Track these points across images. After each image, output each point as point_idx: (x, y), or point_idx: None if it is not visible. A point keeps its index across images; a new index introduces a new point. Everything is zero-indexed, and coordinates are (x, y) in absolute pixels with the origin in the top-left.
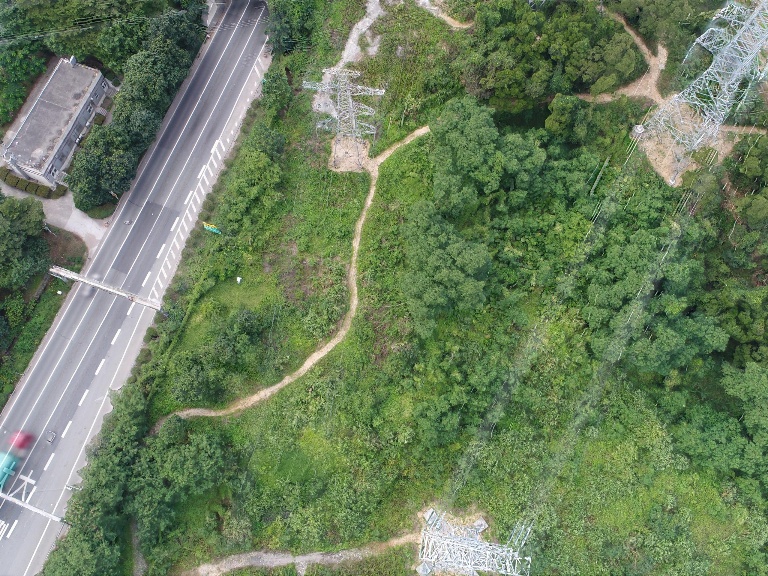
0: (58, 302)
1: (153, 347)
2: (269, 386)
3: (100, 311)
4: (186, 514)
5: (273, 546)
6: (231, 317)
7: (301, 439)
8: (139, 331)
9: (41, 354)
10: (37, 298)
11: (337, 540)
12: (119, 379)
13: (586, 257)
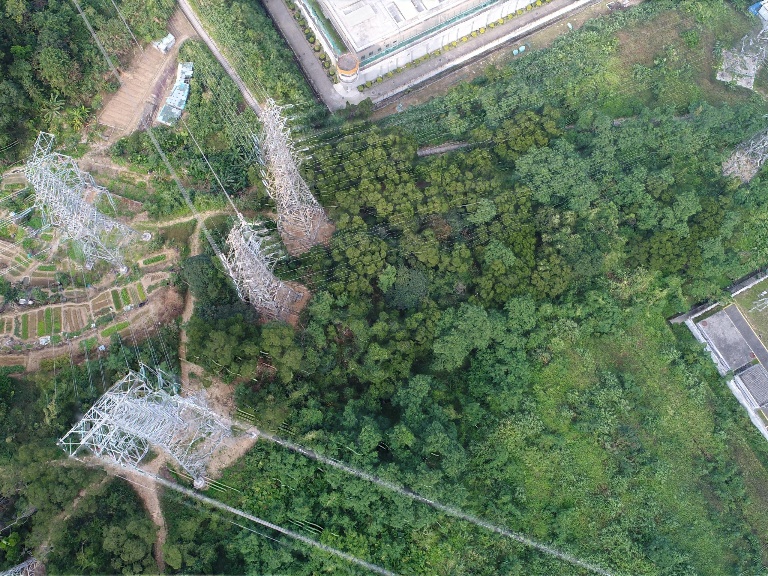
0: None
1: None
2: None
3: None
4: None
5: None
6: None
7: None
8: None
9: None
10: None
11: None
12: None
13: (356, 529)
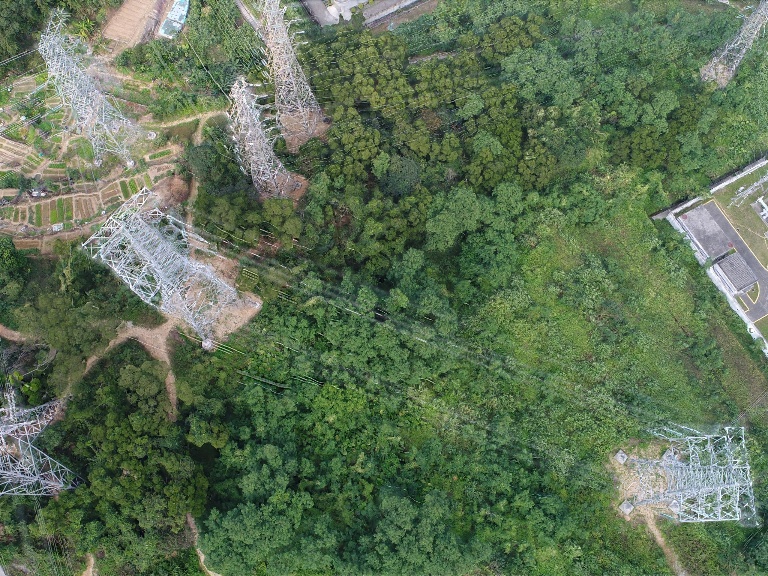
0: None
1: None
2: None
3: None
4: None
5: None
6: None
7: None
8: None
9: None
10: None
11: None
12: None
13: None
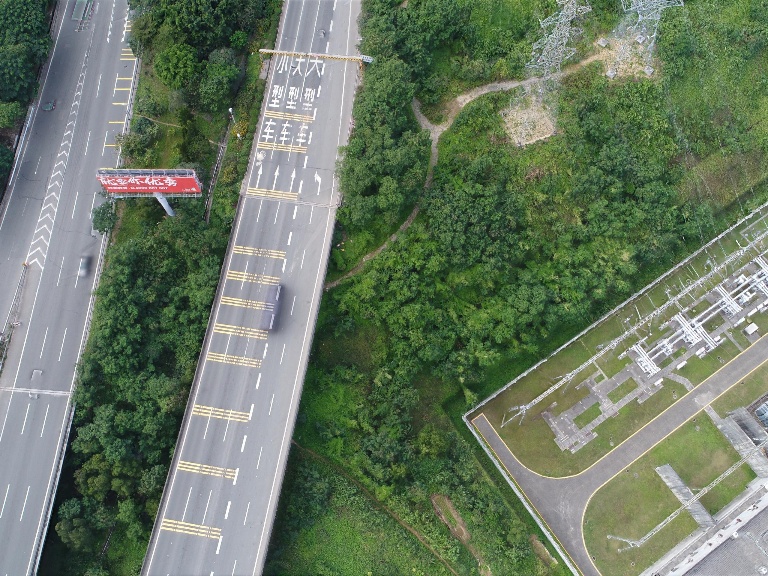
0: None
1: None
2: None
3: None
4: (435, 67)
5: (504, 73)
6: None
7: None
8: None
9: None
10: None
11: None
12: None
13: None
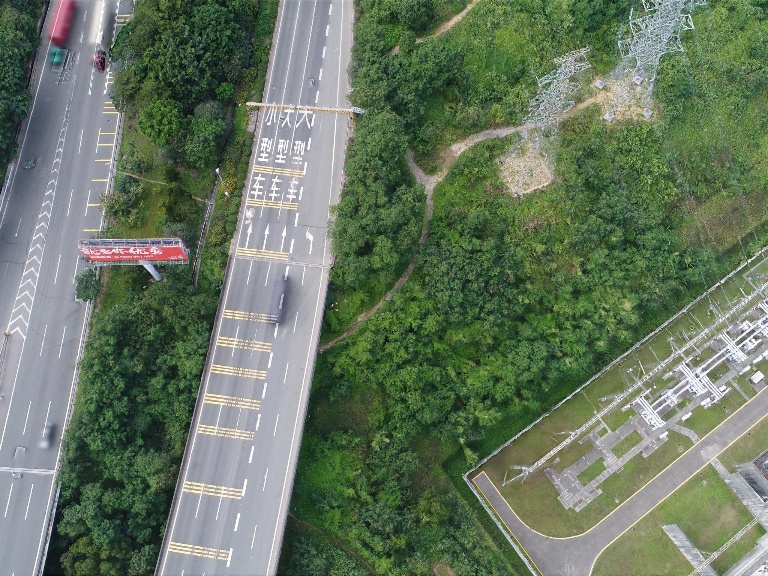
0: None
1: (364, 4)
2: (458, 13)
3: None
4: (428, 115)
5: (500, 120)
6: None
7: (496, 39)
8: (346, 2)
9: (278, 34)
10: None
11: None
12: (346, 34)
13: None
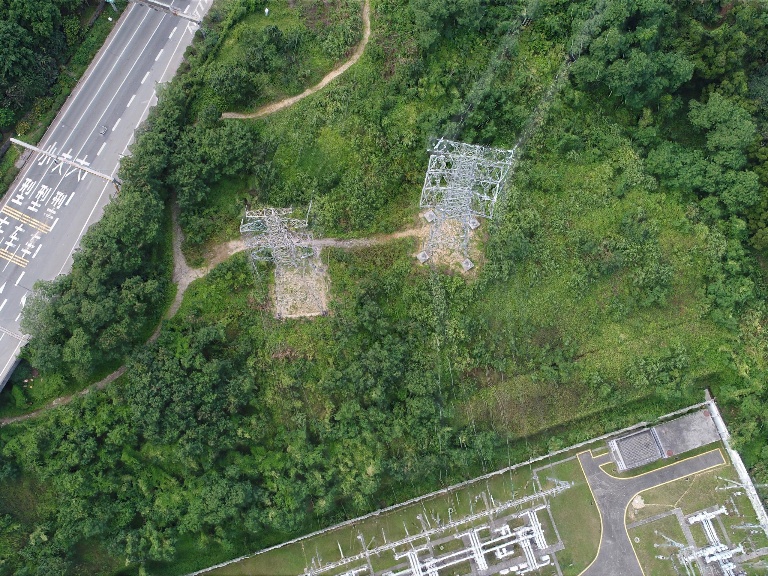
0: (109, 26)
1: (192, 60)
2: (292, 96)
3: (145, 35)
4: (218, 200)
5: None
6: (260, 32)
7: (319, 138)
8: (179, 51)
9: (94, 67)
10: (90, 26)
11: (349, 229)
12: None
13: (571, 1)
